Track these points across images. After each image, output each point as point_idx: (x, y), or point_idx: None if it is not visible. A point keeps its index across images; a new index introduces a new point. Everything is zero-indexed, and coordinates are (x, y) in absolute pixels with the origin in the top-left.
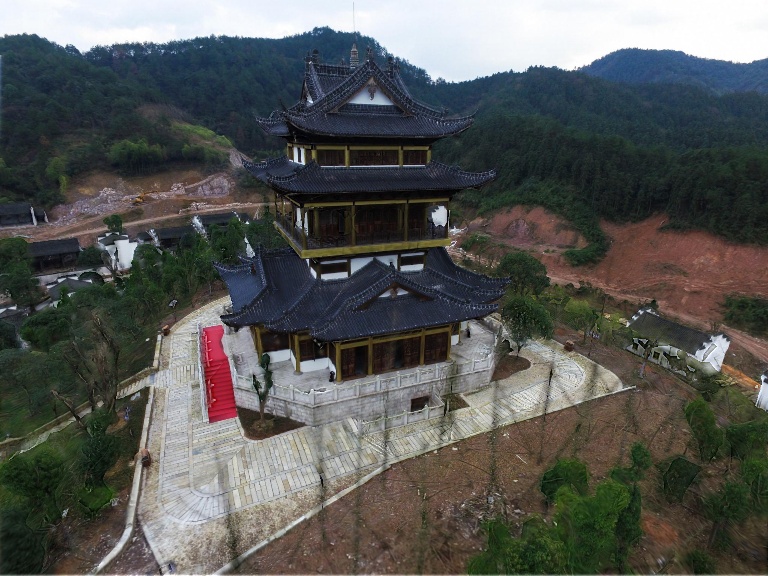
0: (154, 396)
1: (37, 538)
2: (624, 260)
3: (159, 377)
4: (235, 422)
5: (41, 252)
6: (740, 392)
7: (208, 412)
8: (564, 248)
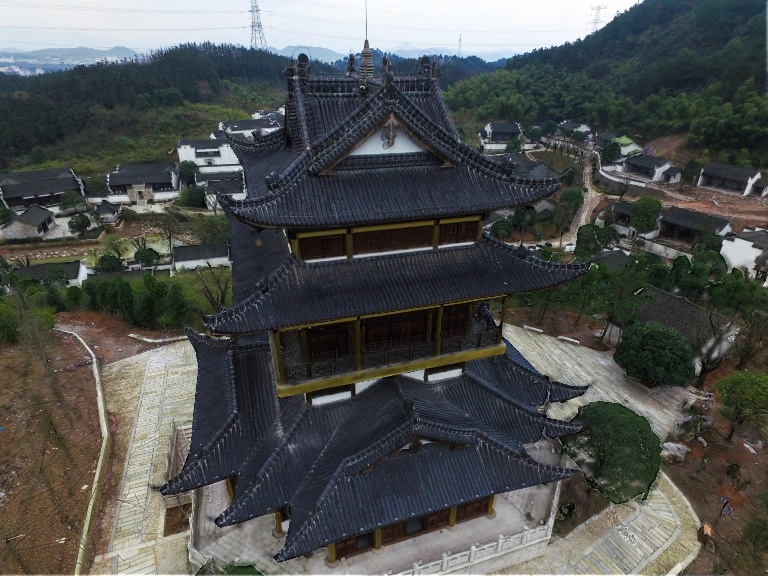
0: None
1: (153, 311)
2: None
3: None
4: None
5: (682, 221)
6: None
7: None
8: None
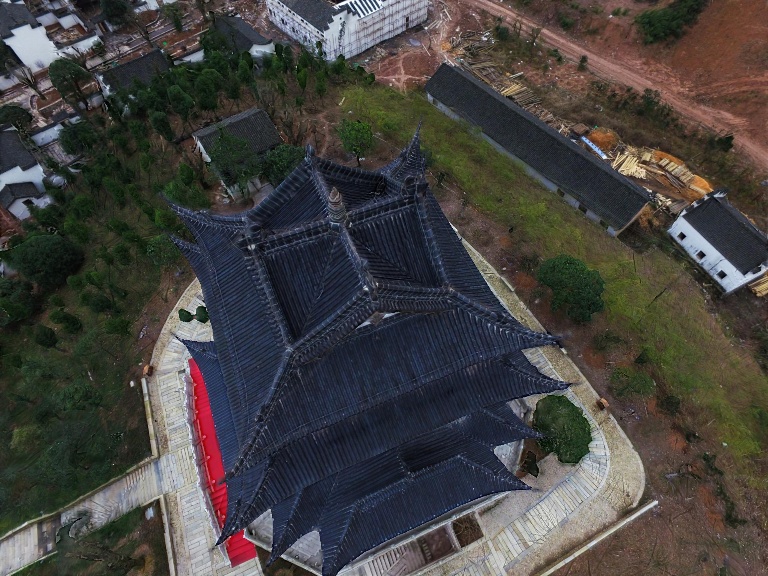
0: (167, 511)
1: None
2: (719, 34)
3: (163, 470)
4: (256, 567)
5: None
6: (767, 417)
7: (227, 553)
8: (642, 2)
